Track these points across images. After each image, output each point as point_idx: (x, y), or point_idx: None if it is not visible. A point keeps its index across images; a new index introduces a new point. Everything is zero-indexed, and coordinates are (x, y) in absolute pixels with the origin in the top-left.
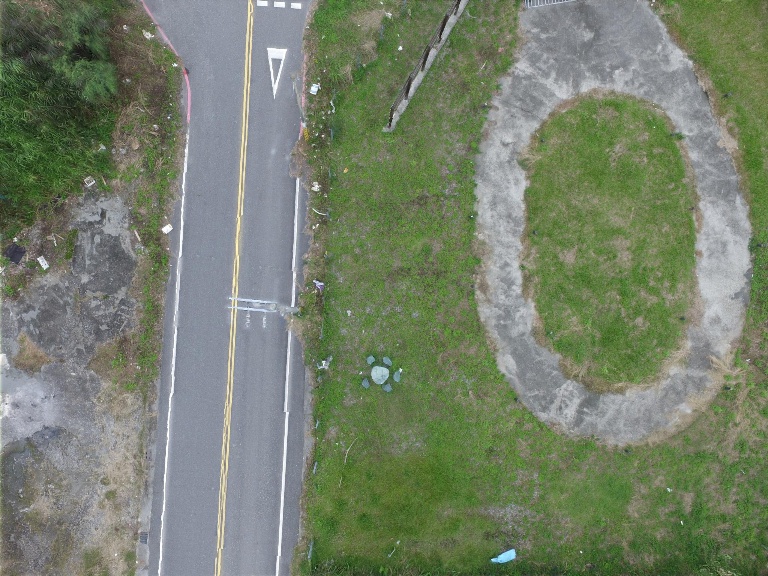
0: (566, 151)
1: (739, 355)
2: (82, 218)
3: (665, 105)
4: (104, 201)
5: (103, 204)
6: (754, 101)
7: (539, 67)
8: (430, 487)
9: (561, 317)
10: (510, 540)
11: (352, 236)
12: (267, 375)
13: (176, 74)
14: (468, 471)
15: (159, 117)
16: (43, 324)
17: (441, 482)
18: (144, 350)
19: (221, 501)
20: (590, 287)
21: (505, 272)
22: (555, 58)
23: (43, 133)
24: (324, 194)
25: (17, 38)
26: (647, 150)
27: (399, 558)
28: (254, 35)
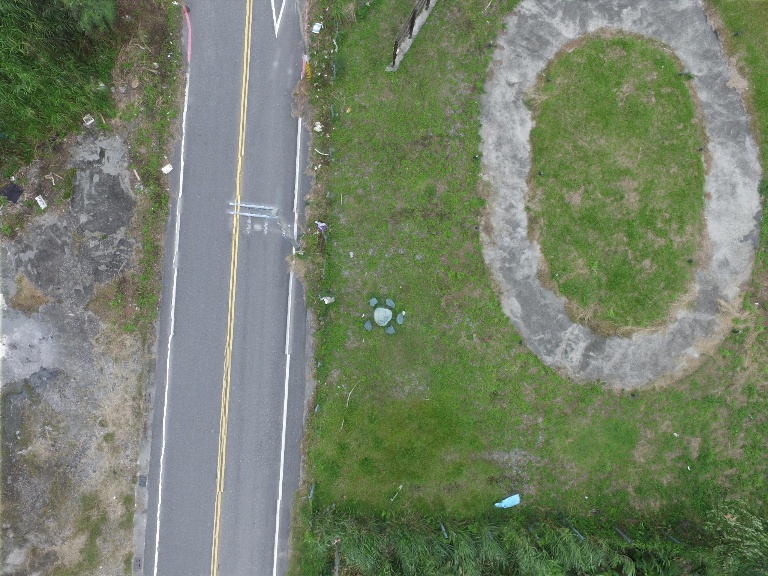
0: (573, 91)
1: (748, 298)
2: (81, 157)
3: (674, 45)
4: (103, 140)
5: (102, 143)
6: (764, 40)
7: (545, 6)
8: (433, 431)
9: (567, 260)
10: (514, 485)
11: (355, 177)
12: (268, 317)
13: (176, 12)
14: (472, 415)
15: (159, 55)
16: (41, 264)
17: (444, 426)
18: (143, 291)
19: (221, 444)
20: (596, 229)
21: (510, 214)
22: None
23: (41, 65)
24: (326, 134)
25: None
26: (655, 90)
27: (401, 503)
28: None
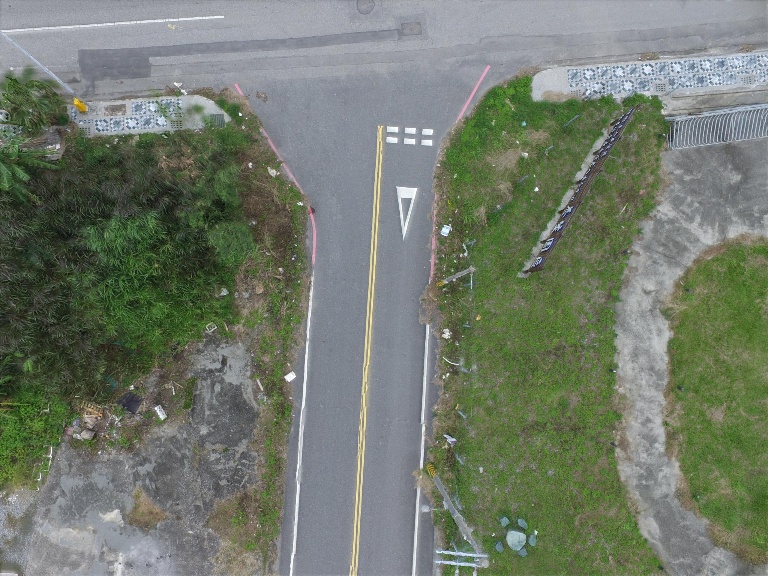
0: (713, 302)
1: None
2: (202, 365)
3: None
4: (225, 347)
5: (224, 350)
6: None
7: (682, 211)
8: None
9: (707, 478)
10: None
11: (485, 387)
12: (394, 536)
13: (301, 213)
14: None
15: (284, 259)
16: (160, 478)
17: None
18: (265, 507)
19: None
20: (739, 448)
21: (647, 428)
22: (699, 201)
23: (174, 289)
24: (455, 342)
25: (151, 191)
26: None
27: None
28: (383, 173)
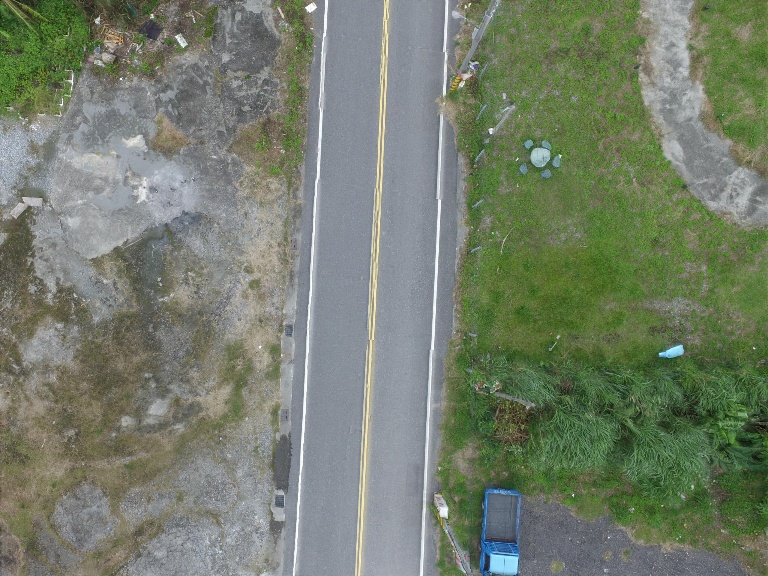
0: None
1: None
2: None
3: None
4: None
5: None
6: None
7: None
8: (592, 279)
9: (731, 100)
10: (678, 335)
11: (507, 15)
12: (418, 161)
13: None
14: (632, 263)
15: None
16: (182, 104)
17: (604, 274)
18: (288, 133)
19: (372, 290)
20: (764, 66)
21: (671, 53)
22: None
23: None
24: None
25: None
26: None
27: (559, 354)
28: None
